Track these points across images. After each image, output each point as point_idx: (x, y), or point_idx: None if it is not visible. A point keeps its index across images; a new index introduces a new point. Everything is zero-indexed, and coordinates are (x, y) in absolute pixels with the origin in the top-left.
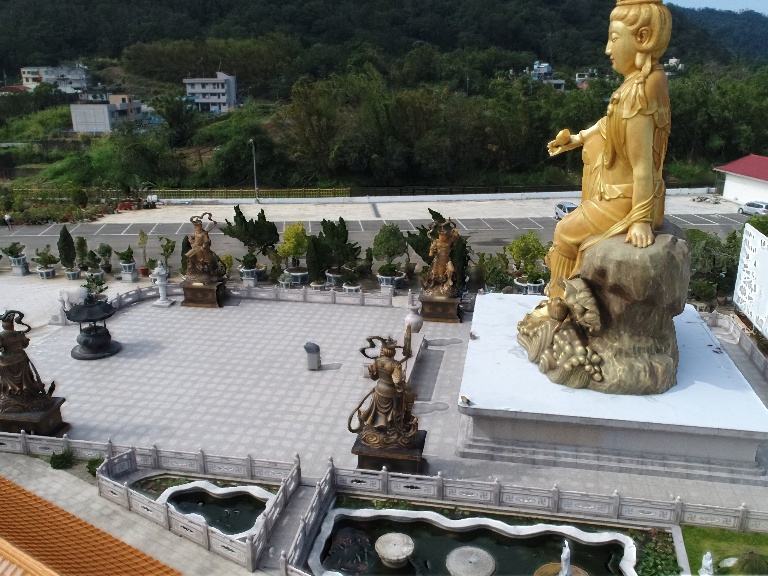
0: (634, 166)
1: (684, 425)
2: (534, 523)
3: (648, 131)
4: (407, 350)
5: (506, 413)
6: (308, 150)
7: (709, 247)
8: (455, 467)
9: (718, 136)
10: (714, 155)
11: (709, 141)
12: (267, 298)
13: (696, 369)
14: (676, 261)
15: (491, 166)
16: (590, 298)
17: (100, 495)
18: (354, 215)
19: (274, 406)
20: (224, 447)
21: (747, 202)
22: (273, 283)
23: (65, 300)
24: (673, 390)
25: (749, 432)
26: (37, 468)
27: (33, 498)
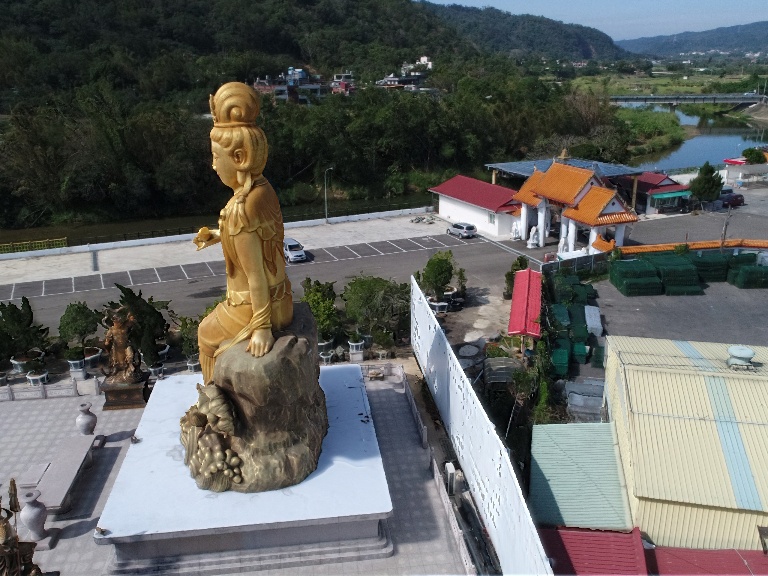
0: (248, 278)
1: (309, 519)
2: None
3: (254, 246)
4: None
5: (142, 537)
6: (35, 182)
7: (388, 296)
8: None
9: (448, 145)
10: (448, 162)
11: (441, 150)
12: None
13: (340, 446)
14: (292, 365)
15: None
16: (222, 406)
17: None
18: (69, 270)
19: None
20: None
21: (453, 223)
22: None
23: None
24: (311, 477)
25: (364, 516)
26: None
27: None
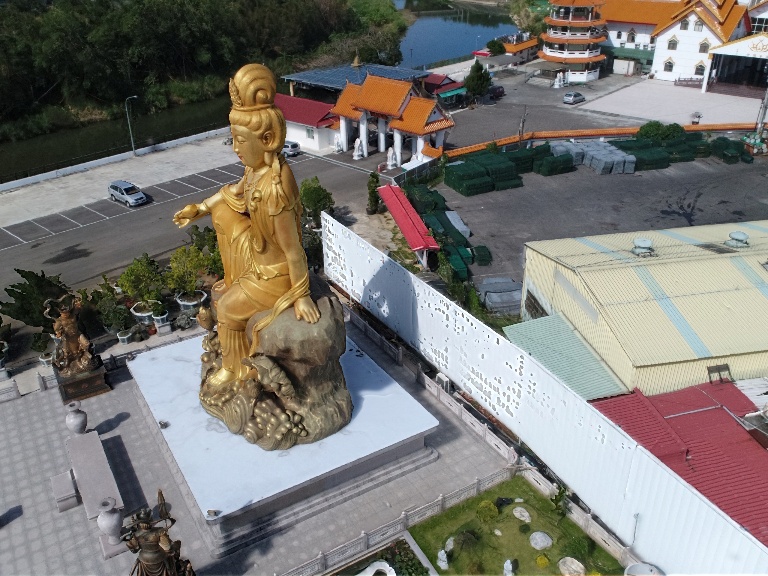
0: (287, 252)
1: (382, 449)
2: None
3: (293, 222)
4: (172, 519)
5: (251, 506)
6: None
7: None
8: (221, 573)
9: (204, 50)
10: (204, 67)
11: (197, 55)
12: None
13: (356, 382)
14: (340, 323)
15: None
16: (281, 373)
17: None
18: None
19: None
20: None
21: None
22: None
23: None
24: (355, 414)
25: (422, 433)
26: None
27: None
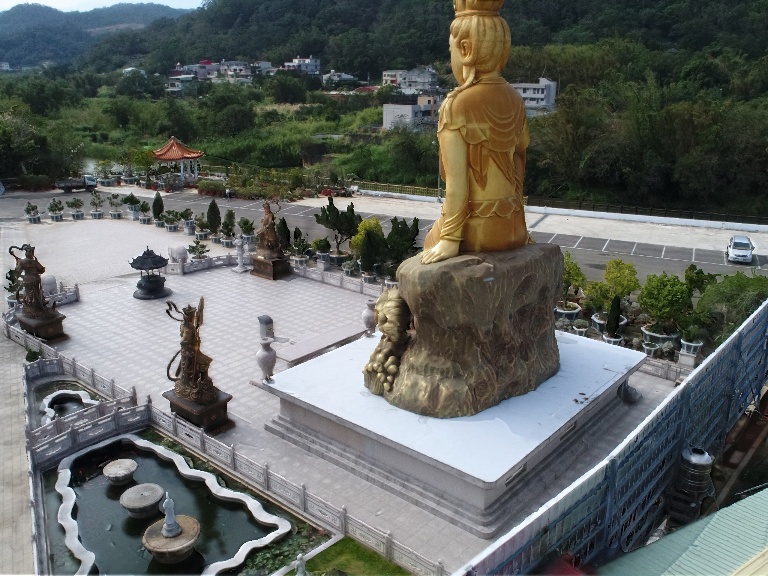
0: None
1: (410, 447)
2: (244, 492)
3: (454, 146)
4: None
5: (288, 397)
6: (561, 158)
7: None
8: (249, 434)
9: None
10: None
11: None
12: (316, 279)
13: (522, 409)
14: (455, 283)
15: None
16: (394, 308)
17: None
18: None
19: None
20: (130, 375)
21: None
22: None
23: (170, 254)
24: (459, 419)
25: (460, 472)
26: (20, 357)
27: None
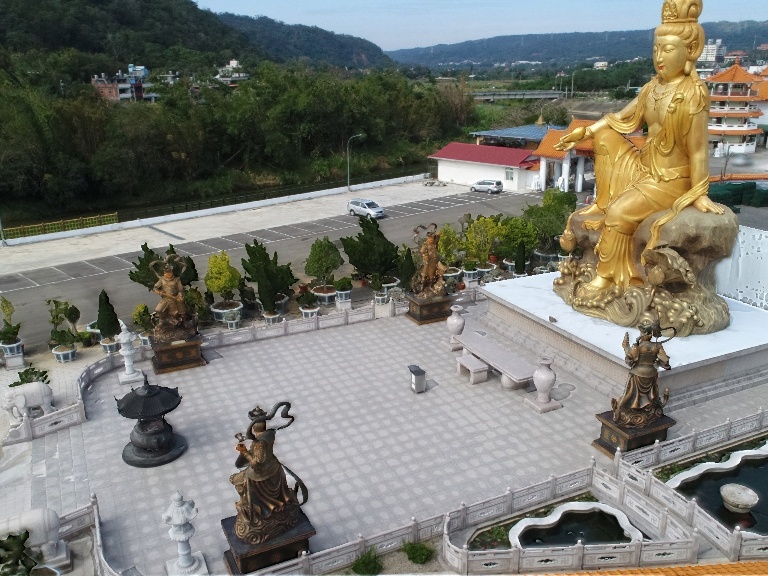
0: (696, 151)
1: None
2: (758, 443)
3: None
4: None
5: (682, 368)
6: None
7: None
8: None
9: (362, 130)
10: (359, 147)
11: None
12: (242, 341)
13: None
14: None
15: (174, 175)
16: (686, 261)
17: (467, 575)
18: (152, 241)
19: (450, 434)
20: (480, 485)
21: (476, 182)
22: (205, 326)
23: (20, 406)
24: (730, 321)
25: None
26: None
27: (597, 575)
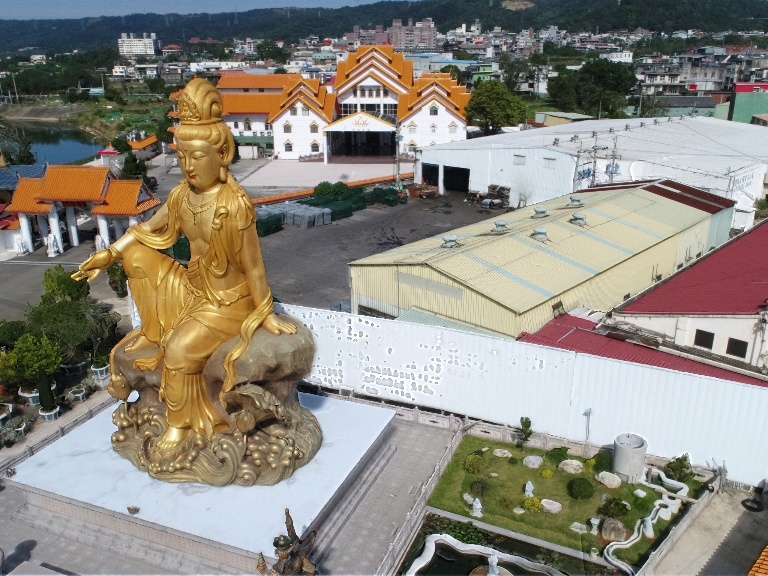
0: (253, 268)
1: (372, 444)
2: None
3: None
4: None
5: (307, 531)
6: None
7: None
8: None
9: None
10: None
11: None
12: None
13: None
14: None
15: None
16: (273, 395)
17: None
18: None
19: None
20: None
21: None
22: None
23: None
24: None
25: None
26: None
27: None
